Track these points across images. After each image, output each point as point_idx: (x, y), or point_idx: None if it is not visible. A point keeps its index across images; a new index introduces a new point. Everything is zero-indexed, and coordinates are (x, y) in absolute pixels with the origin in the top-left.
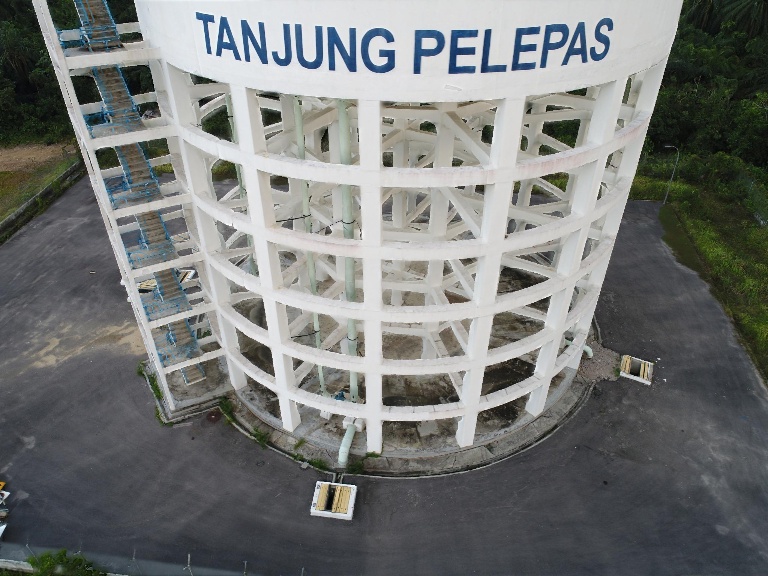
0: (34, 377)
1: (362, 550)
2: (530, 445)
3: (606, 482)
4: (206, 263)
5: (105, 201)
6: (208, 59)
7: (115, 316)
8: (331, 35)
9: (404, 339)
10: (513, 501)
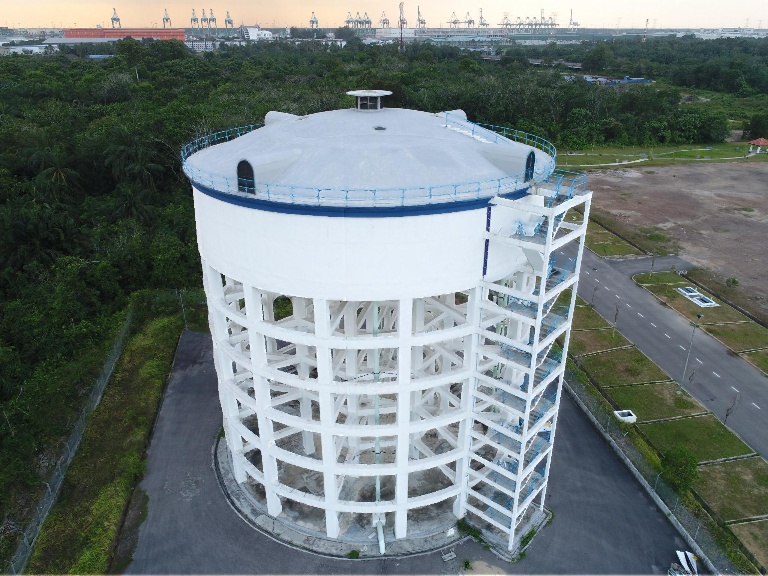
0: None
1: None
2: None
3: None
4: None
5: None
6: None
7: None
8: None
9: None
10: None
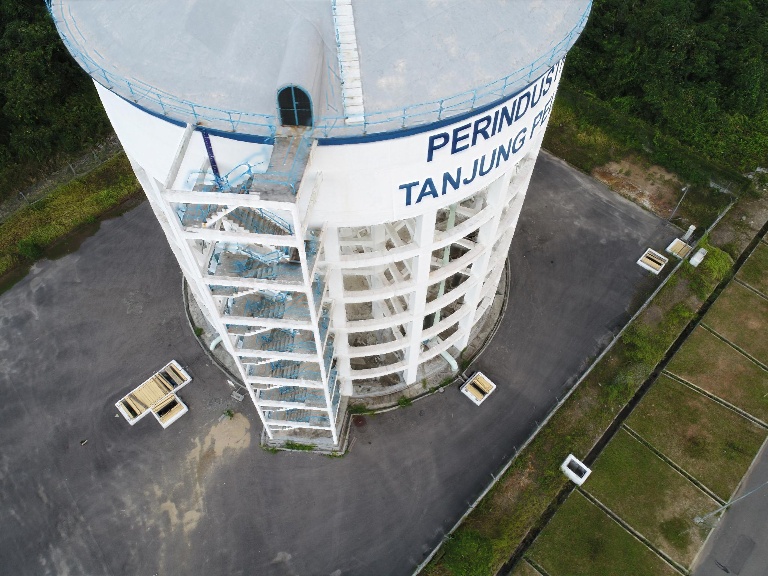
0: (205, 535)
1: (517, 393)
2: (506, 274)
3: (552, 261)
4: (340, 335)
5: (321, 353)
6: (406, 209)
7: (177, 446)
8: (500, 150)
9: (386, 275)
10: (536, 307)
